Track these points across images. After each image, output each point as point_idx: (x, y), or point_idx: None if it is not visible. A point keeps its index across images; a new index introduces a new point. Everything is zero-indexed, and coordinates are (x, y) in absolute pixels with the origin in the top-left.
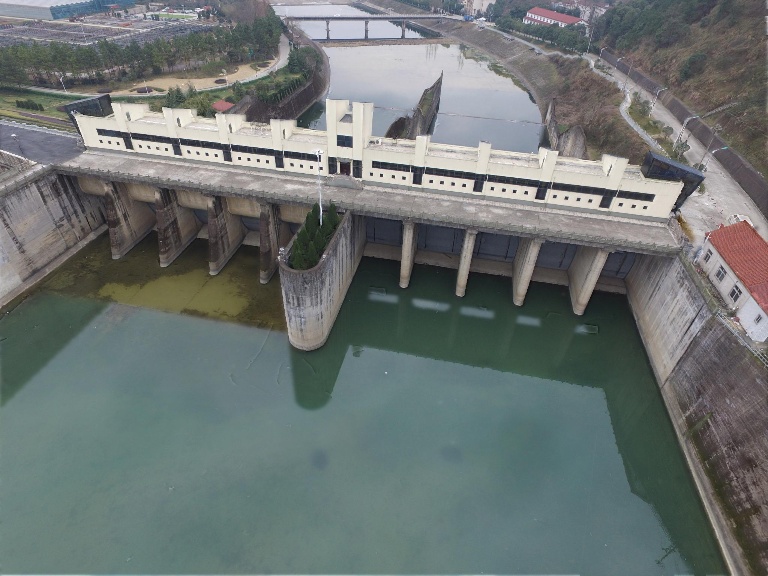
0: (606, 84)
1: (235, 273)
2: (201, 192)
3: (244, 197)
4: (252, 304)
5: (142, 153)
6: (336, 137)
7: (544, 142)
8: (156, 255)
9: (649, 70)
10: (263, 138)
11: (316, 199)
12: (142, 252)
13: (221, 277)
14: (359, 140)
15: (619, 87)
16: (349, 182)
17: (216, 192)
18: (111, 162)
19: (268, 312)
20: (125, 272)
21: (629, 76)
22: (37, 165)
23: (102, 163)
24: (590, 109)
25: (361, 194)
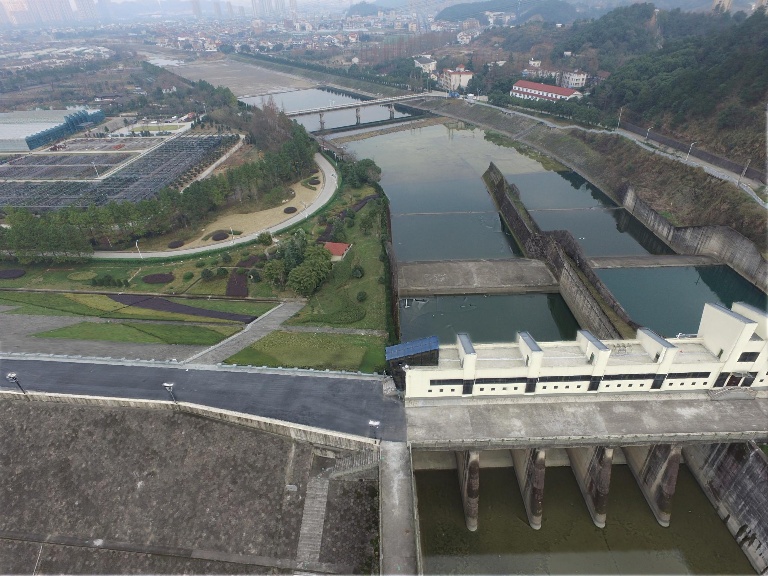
0: (687, 168)
1: (620, 517)
2: (607, 446)
3: (661, 443)
4: (689, 565)
5: (480, 395)
6: (740, 355)
7: (633, 227)
8: (510, 510)
9: (724, 152)
10: (648, 365)
11: (752, 434)
12: (490, 509)
13: (613, 528)
14: (766, 355)
15: (707, 172)
16: (742, 394)
17: (626, 443)
18: (455, 416)
19: (719, 574)
20: (504, 550)
21: (745, 170)
22: (382, 444)
23: (448, 421)
24: (676, 193)
25: (763, 407)
